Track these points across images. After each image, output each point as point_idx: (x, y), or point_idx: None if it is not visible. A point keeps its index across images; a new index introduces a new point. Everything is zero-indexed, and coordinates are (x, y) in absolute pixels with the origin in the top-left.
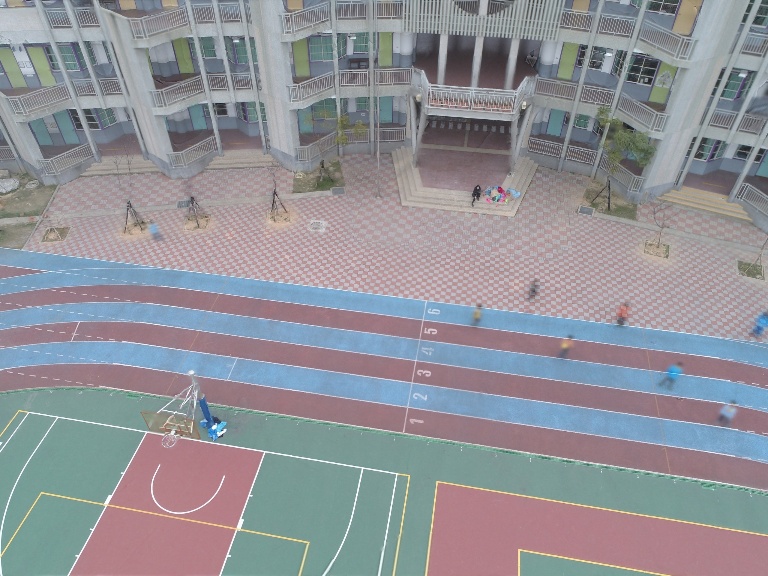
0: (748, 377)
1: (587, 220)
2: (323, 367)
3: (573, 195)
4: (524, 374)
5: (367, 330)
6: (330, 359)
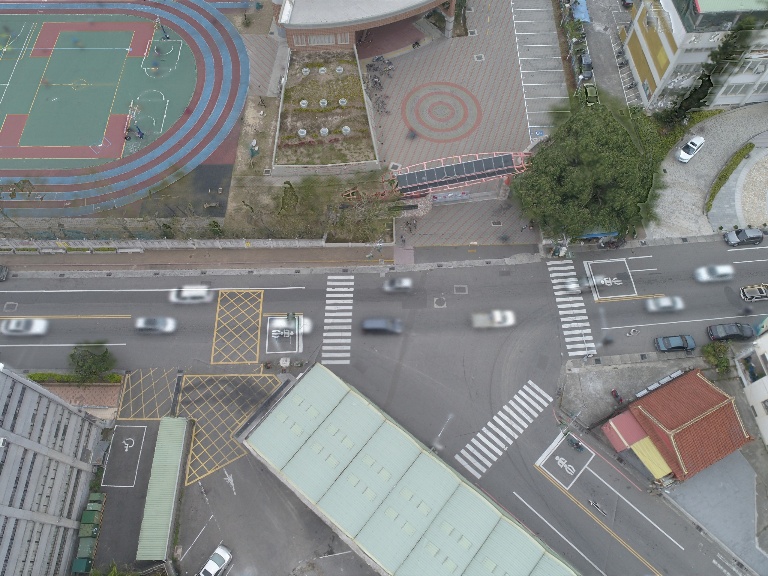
0: None
1: None
2: (16, 3)
3: None
4: None
5: None
6: (18, 1)
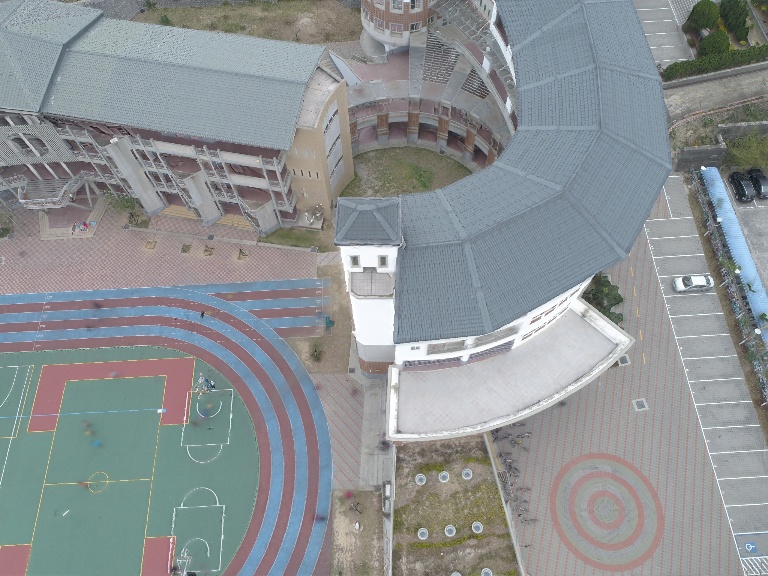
0: (162, 303)
1: (125, 233)
2: (4, 332)
3: (123, 217)
4: (80, 319)
5: (21, 312)
6: (7, 328)
